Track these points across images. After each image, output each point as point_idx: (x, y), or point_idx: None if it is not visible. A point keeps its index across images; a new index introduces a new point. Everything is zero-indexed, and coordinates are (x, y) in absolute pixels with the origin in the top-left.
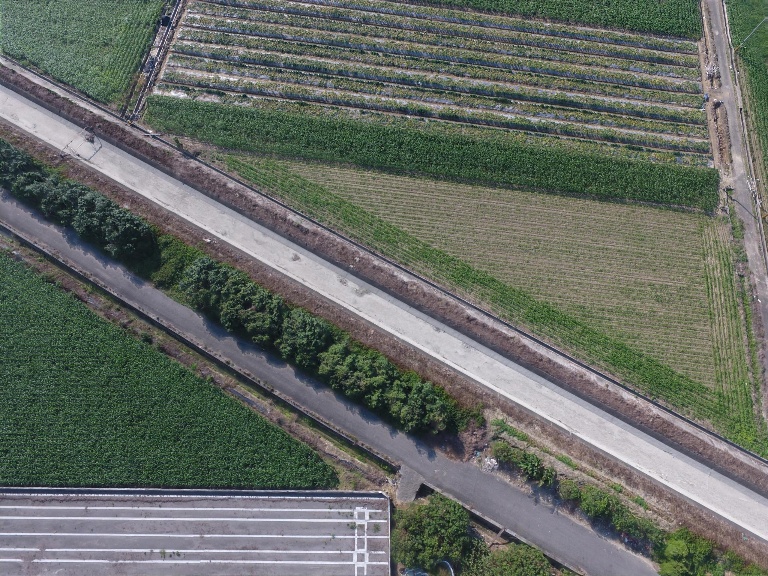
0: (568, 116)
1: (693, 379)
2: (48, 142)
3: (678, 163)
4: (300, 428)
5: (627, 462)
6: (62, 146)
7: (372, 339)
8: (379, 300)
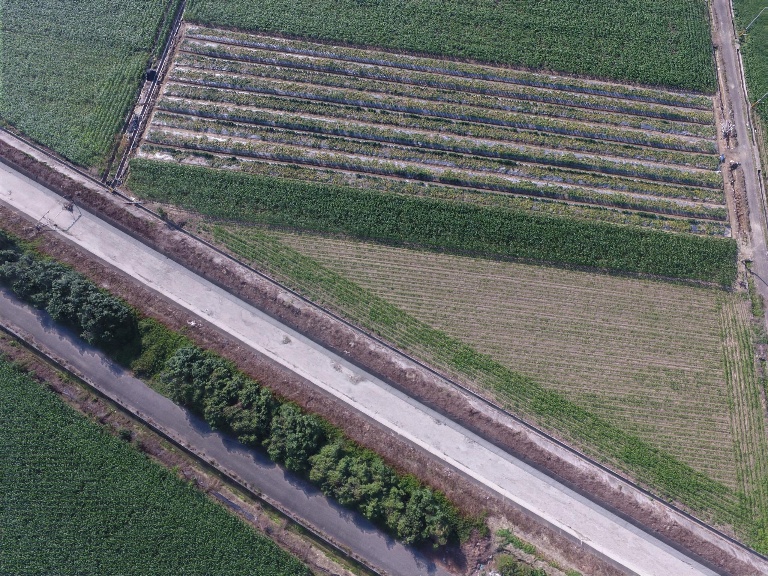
0: (576, 180)
1: (712, 478)
2: (24, 211)
3: (693, 232)
4: (289, 537)
5: (642, 575)
6: (39, 215)
7: (367, 436)
8: (375, 388)
